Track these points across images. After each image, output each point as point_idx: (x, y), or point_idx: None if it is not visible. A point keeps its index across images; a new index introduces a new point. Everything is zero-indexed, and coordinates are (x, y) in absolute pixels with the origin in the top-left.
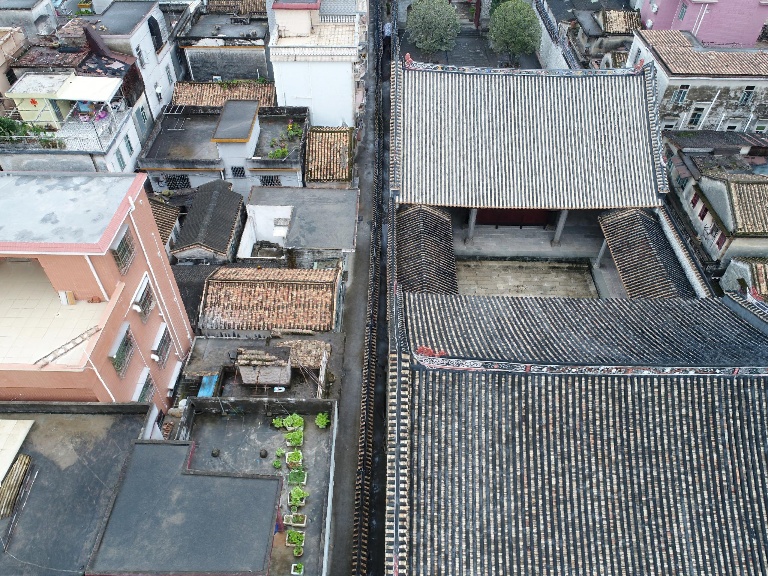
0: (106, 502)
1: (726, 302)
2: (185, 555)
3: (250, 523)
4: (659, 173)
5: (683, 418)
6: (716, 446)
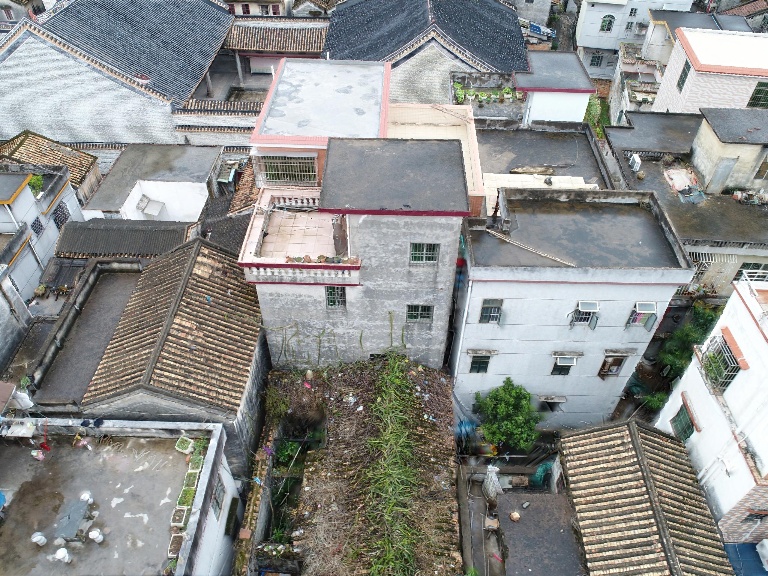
0: (534, 136)
1: (341, 8)
2: (575, 69)
3: (553, 56)
4: (214, 0)
5: (446, 3)
6: (456, 5)
